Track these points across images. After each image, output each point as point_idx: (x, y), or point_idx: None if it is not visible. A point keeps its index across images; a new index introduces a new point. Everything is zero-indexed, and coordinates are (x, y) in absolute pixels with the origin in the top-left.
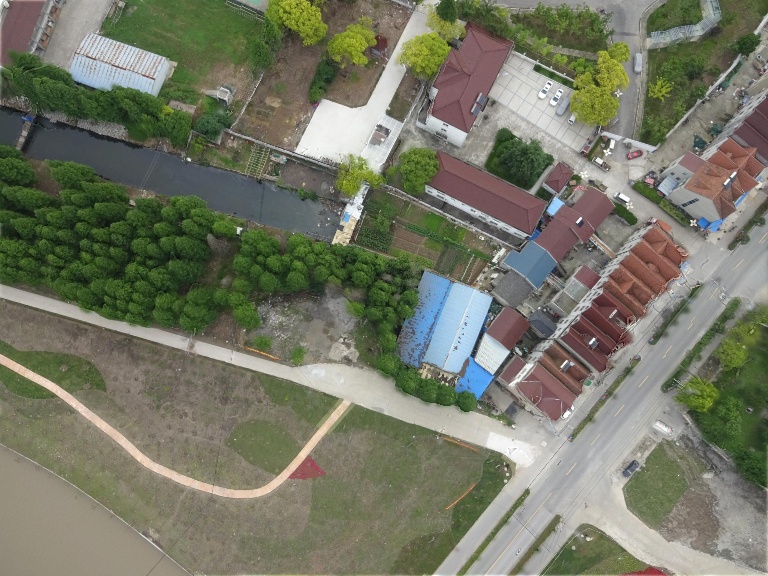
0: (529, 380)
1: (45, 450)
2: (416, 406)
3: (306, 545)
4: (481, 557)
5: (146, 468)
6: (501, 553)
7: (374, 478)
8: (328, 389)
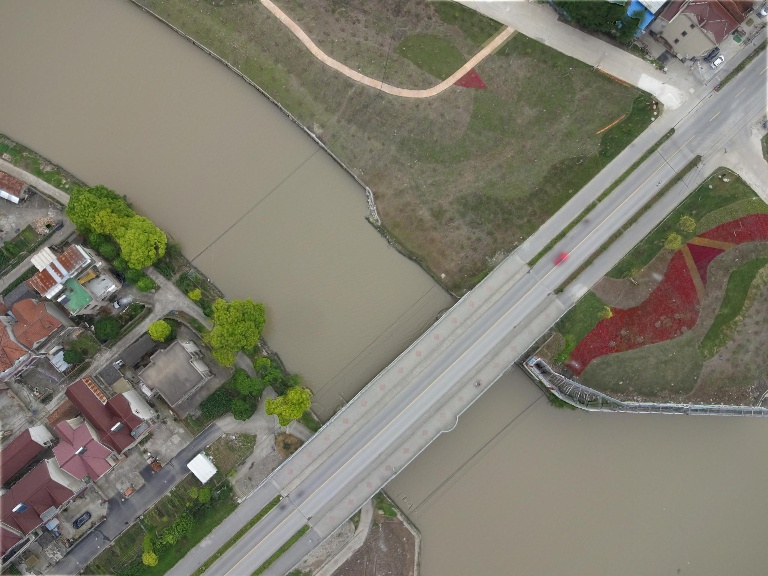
0: (697, 2)
1: (223, 38)
2: (575, 41)
3: (461, 153)
4: (624, 183)
5: (319, 61)
6: (643, 182)
7: (530, 102)
8: (494, 15)
